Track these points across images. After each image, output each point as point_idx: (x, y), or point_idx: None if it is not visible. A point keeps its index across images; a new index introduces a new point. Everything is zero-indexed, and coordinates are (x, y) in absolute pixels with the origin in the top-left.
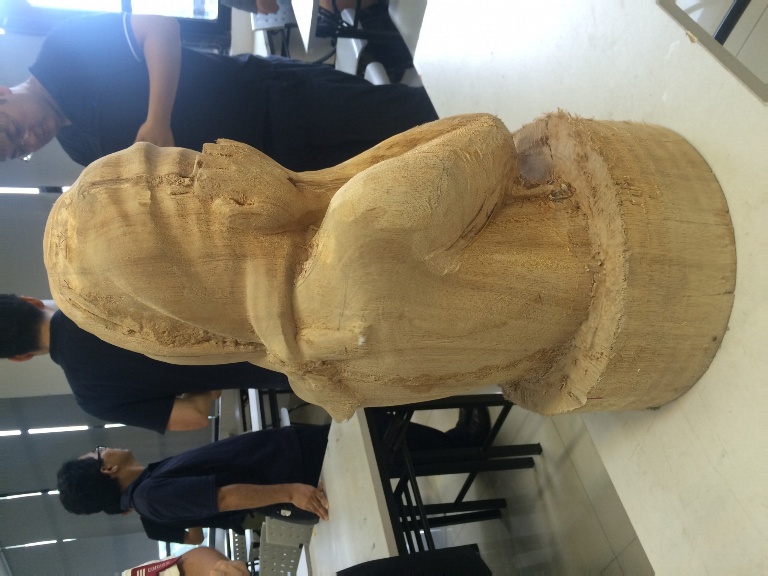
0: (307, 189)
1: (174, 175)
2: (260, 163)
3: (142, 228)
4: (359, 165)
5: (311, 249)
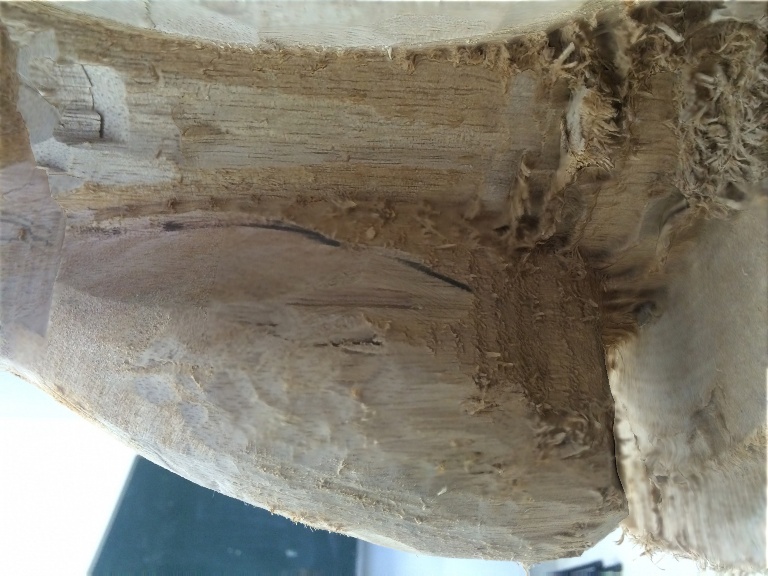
0: None
1: None
2: None
3: None
4: None
5: None
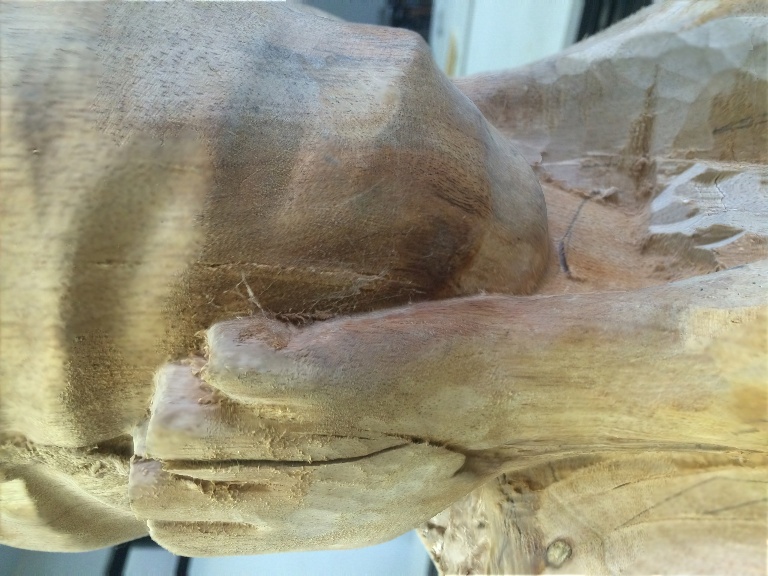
0: (515, 461)
1: (74, 456)
2: (364, 490)
3: (44, 540)
4: (752, 426)
5: (474, 490)
